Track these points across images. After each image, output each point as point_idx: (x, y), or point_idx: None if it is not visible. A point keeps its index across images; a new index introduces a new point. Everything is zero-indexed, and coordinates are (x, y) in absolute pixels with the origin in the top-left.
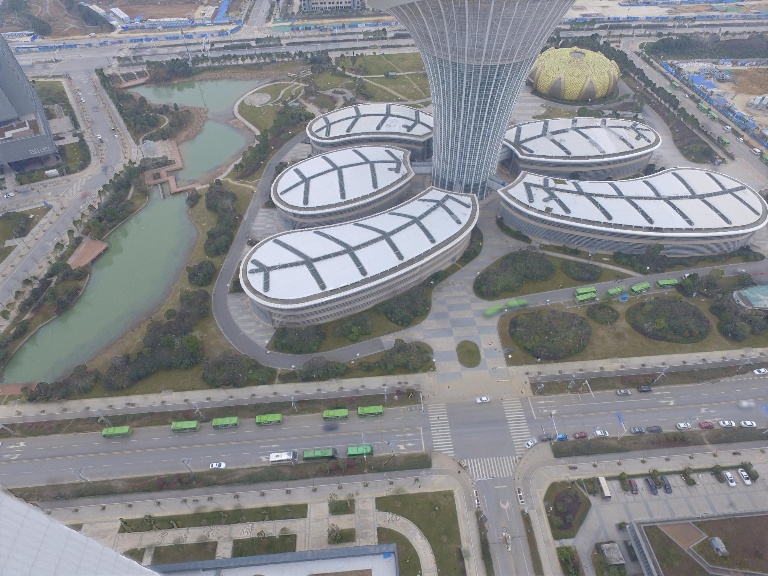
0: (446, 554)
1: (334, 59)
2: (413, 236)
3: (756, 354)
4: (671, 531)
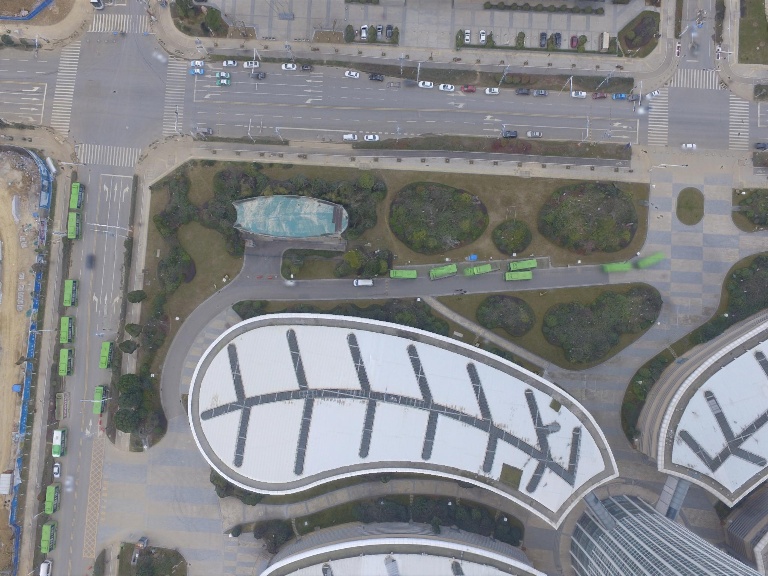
0: (756, 13)
1: None
2: None
3: (360, 160)
4: None
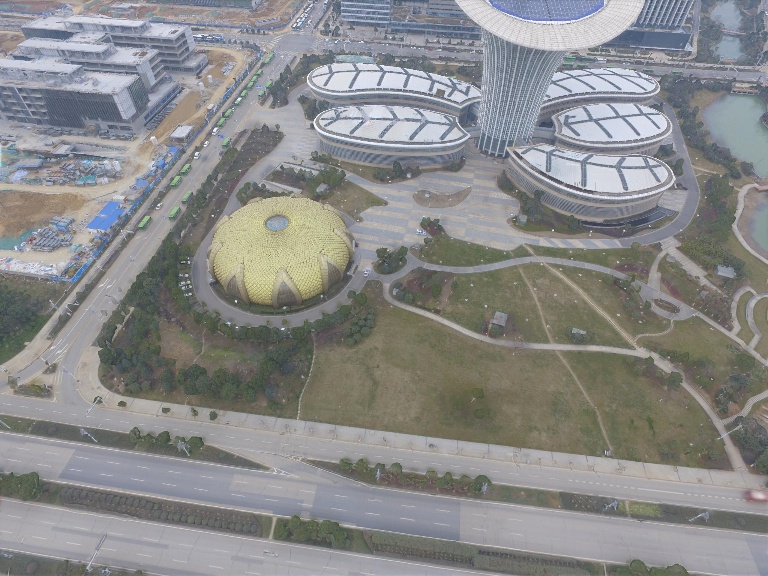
0: None
1: (732, 457)
2: (555, 76)
3: None
4: (473, 25)
